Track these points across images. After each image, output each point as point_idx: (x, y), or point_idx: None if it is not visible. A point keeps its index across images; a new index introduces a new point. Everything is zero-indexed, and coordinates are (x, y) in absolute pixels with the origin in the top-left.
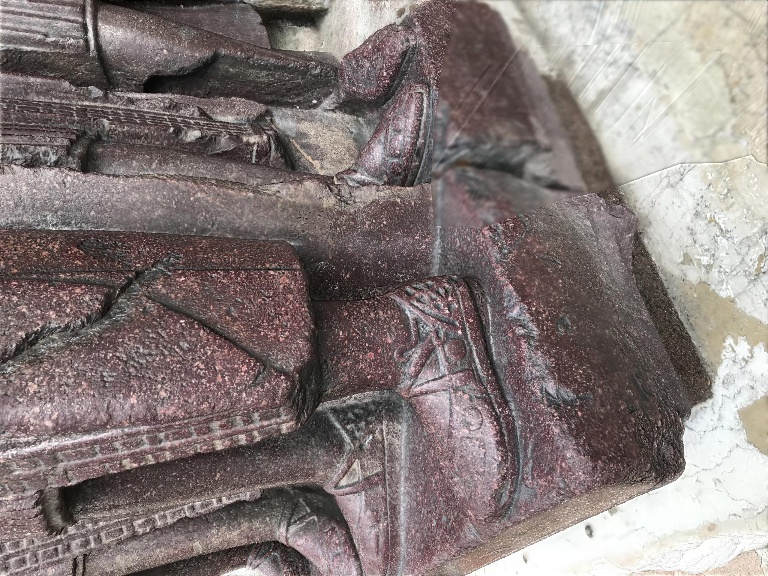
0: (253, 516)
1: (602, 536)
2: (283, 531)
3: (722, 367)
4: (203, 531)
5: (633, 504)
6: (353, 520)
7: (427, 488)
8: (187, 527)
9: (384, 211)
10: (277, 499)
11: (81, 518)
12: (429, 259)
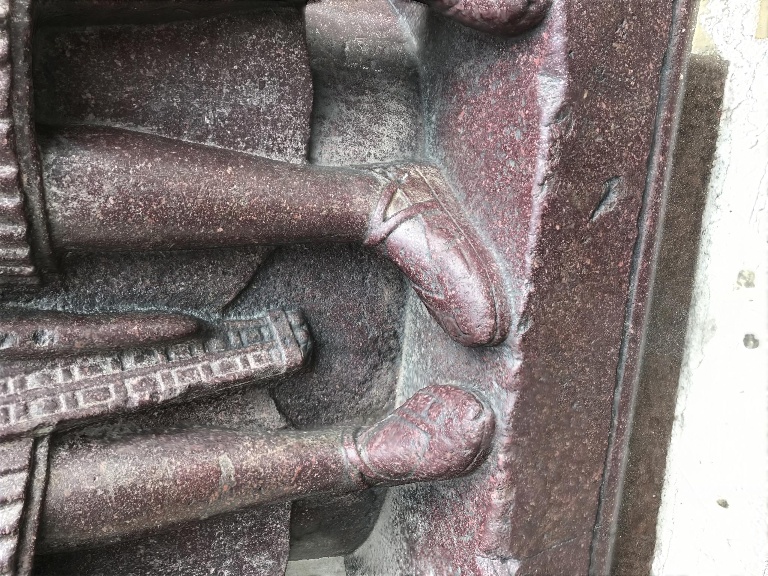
0: (301, 434)
1: (765, 323)
2: (349, 442)
3: (716, 36)
4: (231, 442)
5: (760, 241)
6: (421, 251)
7: (488, 156)
8: (206, 436)
9: (343, 1)
10: (331, 429)
11: (53, 193)
12: (398, 28)
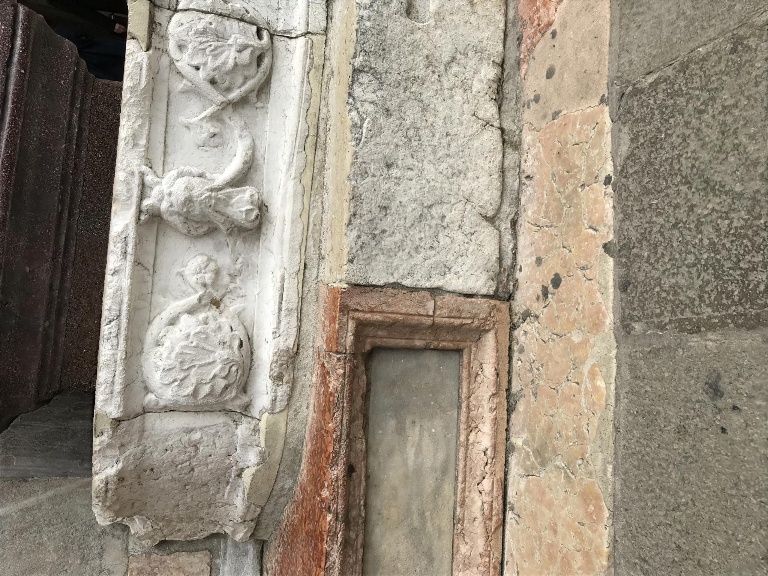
0: None
1: None
2: None
3: None
4: None
5: None
6: None
7: None
8: None
9: None
10: None
11: None
12: None
